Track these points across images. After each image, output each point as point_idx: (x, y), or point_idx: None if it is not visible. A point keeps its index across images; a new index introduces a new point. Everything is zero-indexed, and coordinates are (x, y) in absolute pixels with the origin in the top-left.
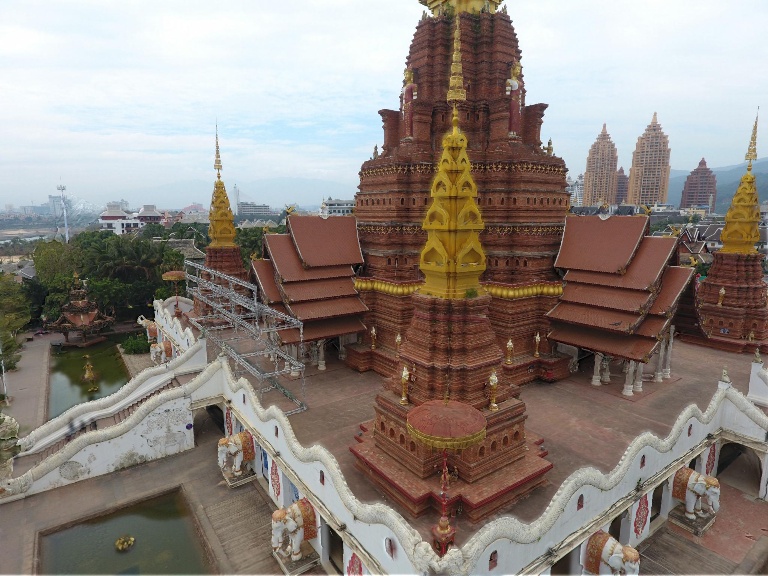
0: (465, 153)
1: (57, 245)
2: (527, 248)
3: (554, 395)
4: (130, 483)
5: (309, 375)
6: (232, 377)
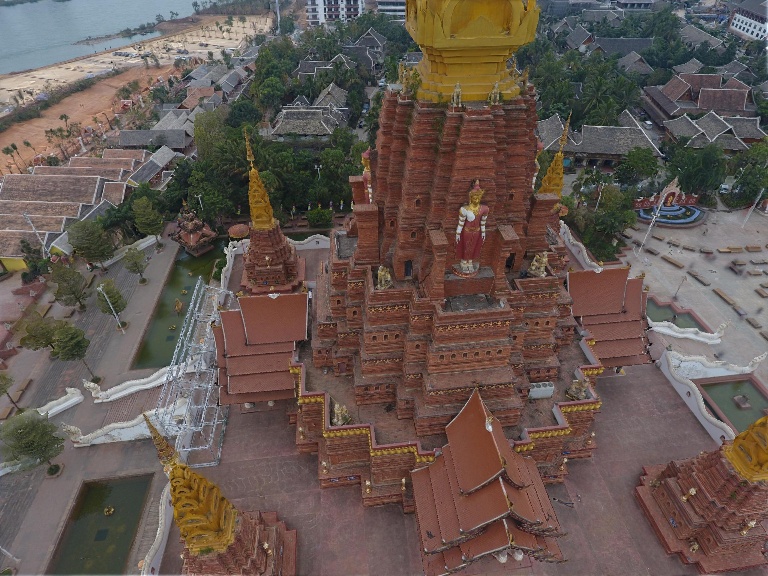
0: (182, 488)
1: (209, 116)
2: None
3: (388, 533)
4: (135, 457)
5: (256, 411)
6: (187, 417)
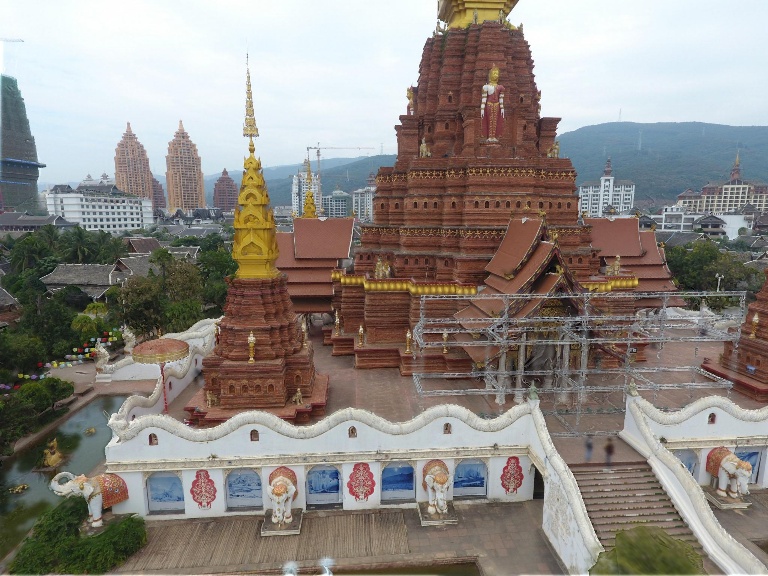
0: None
1: None
2: (588, 244)
3: None
4: None
5: None
6: (661, 411)
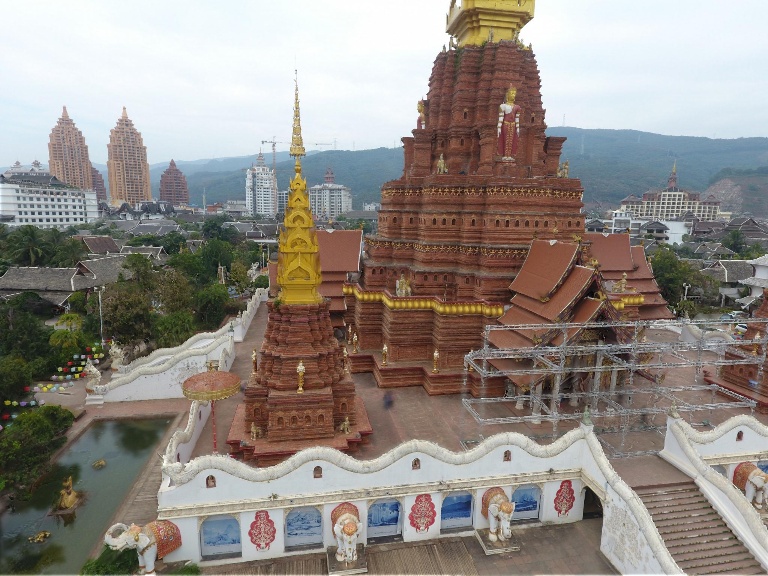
0: None
1: None
2: None
3: None
4: None
5: None
6: None
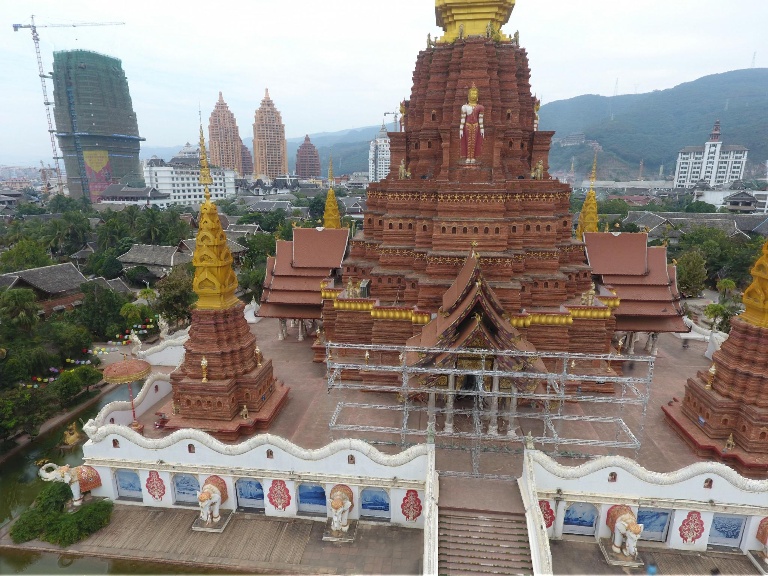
0: None
1: None
2: (580, 262)
3: (642, 370)
4: None
5: (520, 429)
6: (559, 464)
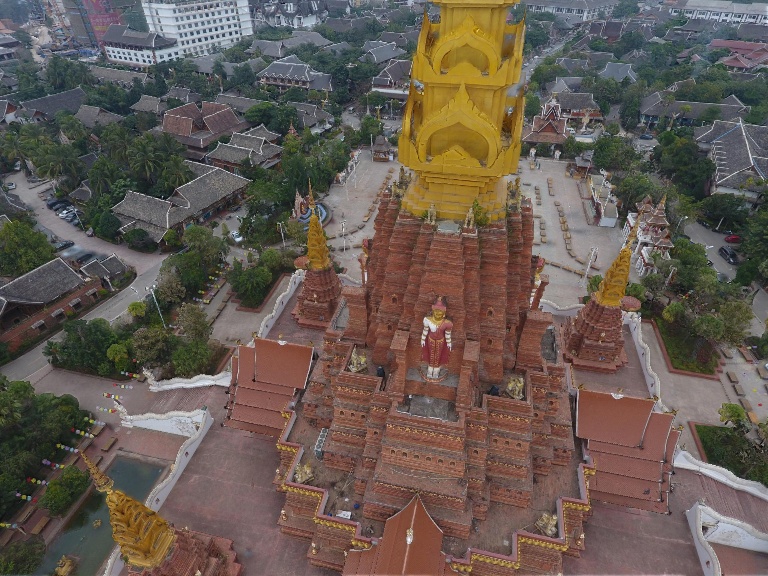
0: None
1: None
2: (563, 437)
3: (605, 543)
4: None
5: None
6: None
